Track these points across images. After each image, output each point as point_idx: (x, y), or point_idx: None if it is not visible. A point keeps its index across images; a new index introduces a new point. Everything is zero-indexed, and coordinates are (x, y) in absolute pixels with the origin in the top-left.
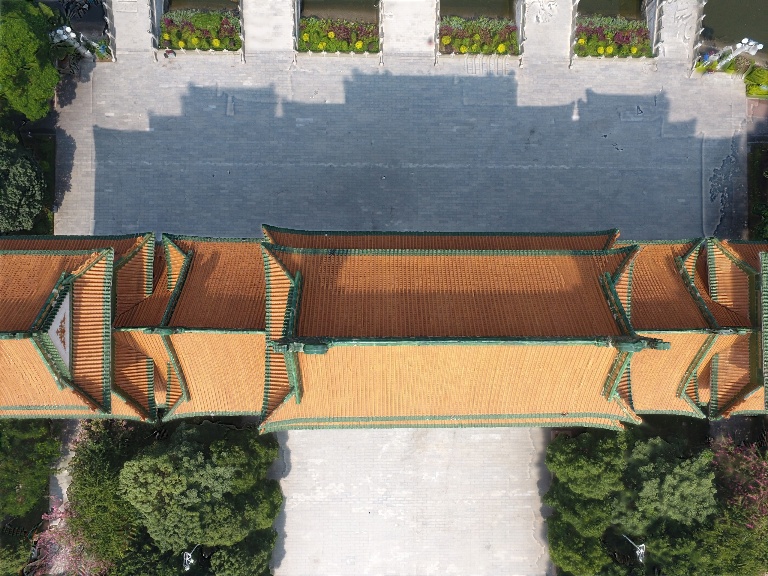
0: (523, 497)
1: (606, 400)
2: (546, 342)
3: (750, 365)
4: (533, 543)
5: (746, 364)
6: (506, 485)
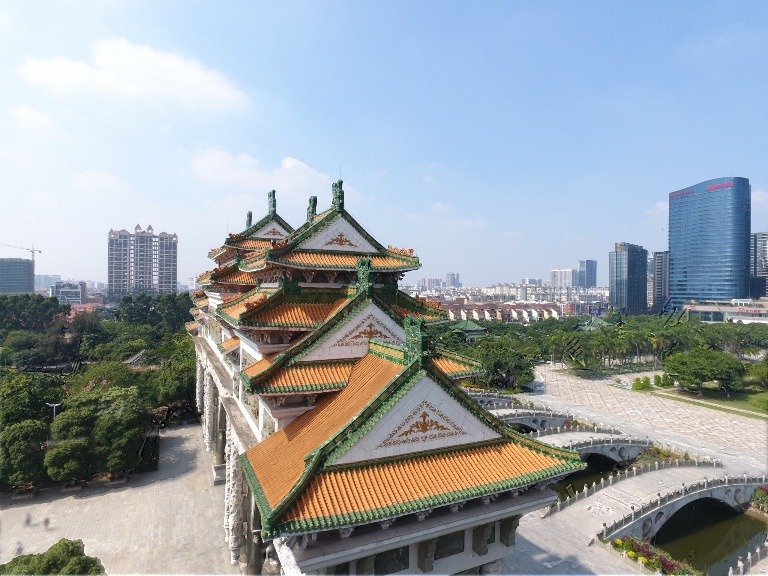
0: None
1: None
2: None
3: None
4: None
5: None
6: None
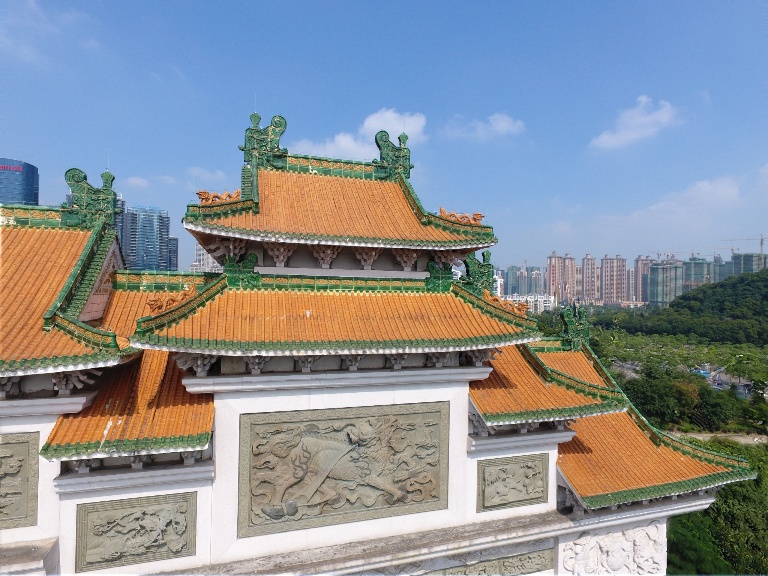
0: None
1: None
2: None
3: None
4: None
5: None
6: None
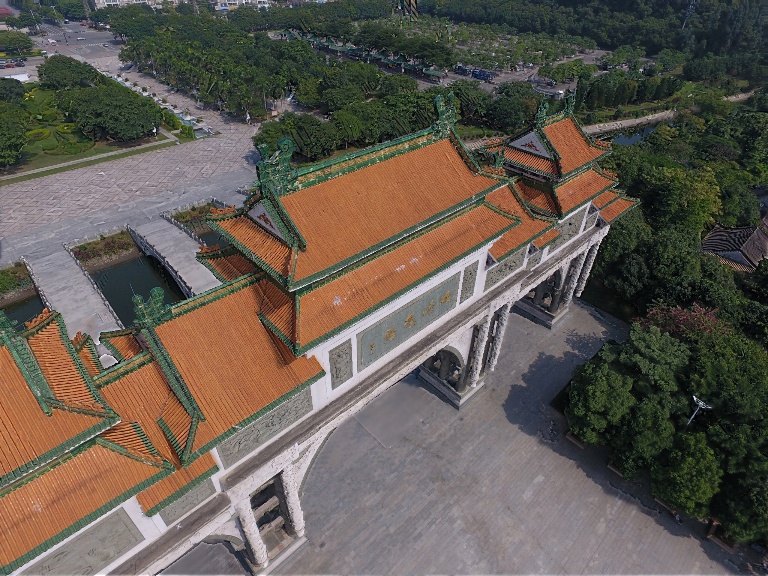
0: (620, 508)
1: (481, 180)
2: (410, 134)
3: (540, 190)
4: (681, 542)
5: (539, 192)
6: (596, 512)
